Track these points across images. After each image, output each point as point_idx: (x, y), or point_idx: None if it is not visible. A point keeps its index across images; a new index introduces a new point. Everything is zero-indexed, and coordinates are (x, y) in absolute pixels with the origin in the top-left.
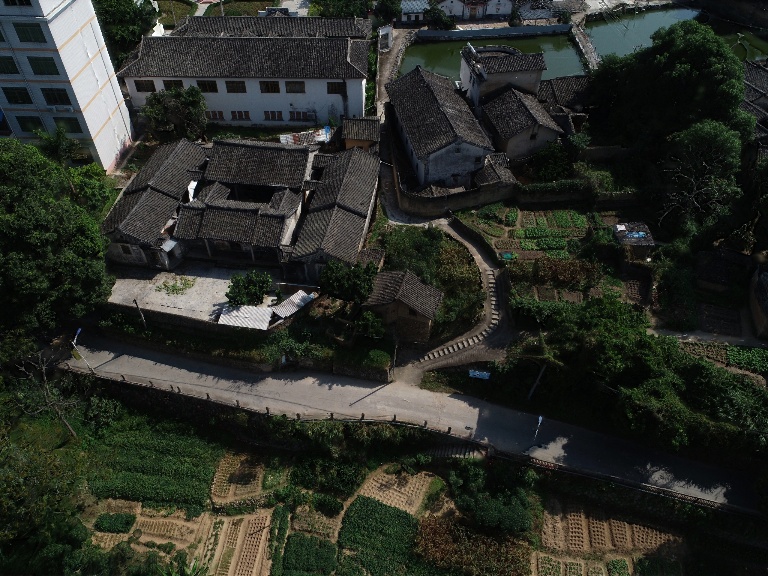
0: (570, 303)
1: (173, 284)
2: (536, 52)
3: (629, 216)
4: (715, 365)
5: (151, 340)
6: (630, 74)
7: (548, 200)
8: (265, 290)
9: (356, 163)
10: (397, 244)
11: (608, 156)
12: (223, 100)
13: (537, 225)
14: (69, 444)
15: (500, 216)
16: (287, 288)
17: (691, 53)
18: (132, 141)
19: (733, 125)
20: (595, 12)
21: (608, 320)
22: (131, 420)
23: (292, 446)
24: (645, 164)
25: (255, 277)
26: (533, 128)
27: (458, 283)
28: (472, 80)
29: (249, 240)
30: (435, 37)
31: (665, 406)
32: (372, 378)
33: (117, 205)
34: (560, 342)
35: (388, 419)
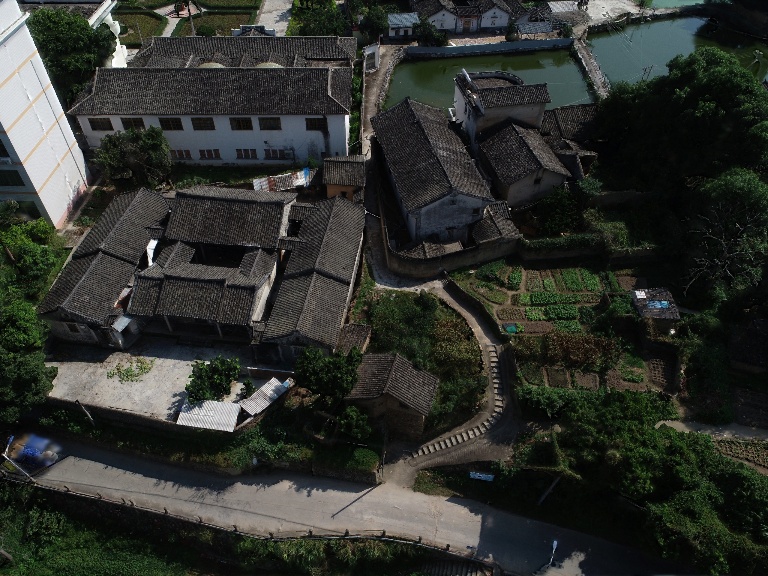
0: (585, 389)
1: (127, 368)
2: (535, 68)
3: (647, 275)
4: (756, 470)
5: (100, 440)
6: (644, 107)
7: (555, 256)
8: (232, 379)
9: (338, 216)
10: (385, 318)
11: (621, 201)
12: (189, 138)
13: (544, 288)
14: (4, 568)
15: (502, 278)
16: (259, 373)
17: (716, 89)
18: (88, 186)
19: (764, 171)
20: (598, 23)
21: (633, 423)
22: (78, 536)
23: (265, 565)
24: (663, 213)
25: (220, 365)
26: (537, 172)
27: (455, 364)
28: (467, 112)
29: (214, 317)
30: (426, 54)
31: (702, 530)
32: (358, 480)
33: (64, 272)
34: (576, 447)
35: (376, 533)
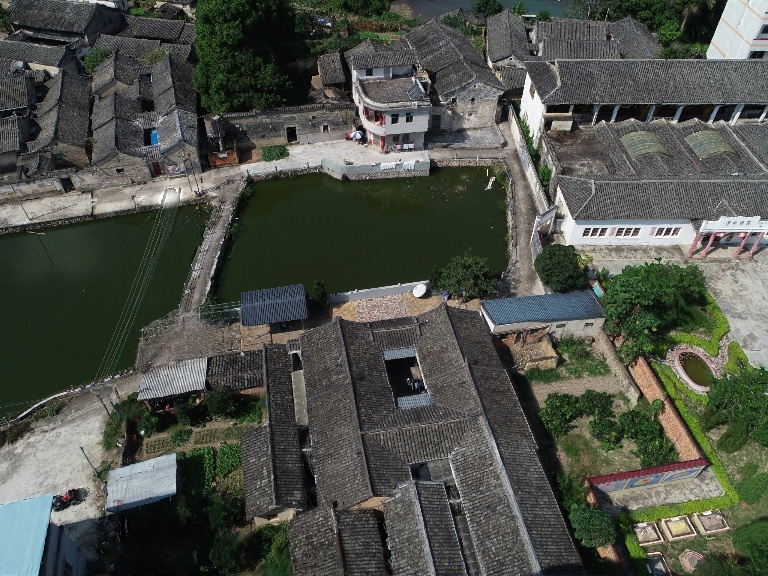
0: None
1: None
2: None
3: None
4: None
5: None
6: None
7: None
8: None
9: None
10: None
11: (306, 67)
12: None
13: None
14: None
15: None
16: None
17: None
18: None
19: None
20: None
21: None
22: None
23: None
24: None
25: None
26: None
27: None
28: None
29: None
30: None
31: None
32: None
33: None
34: (381, 1)
35: None
